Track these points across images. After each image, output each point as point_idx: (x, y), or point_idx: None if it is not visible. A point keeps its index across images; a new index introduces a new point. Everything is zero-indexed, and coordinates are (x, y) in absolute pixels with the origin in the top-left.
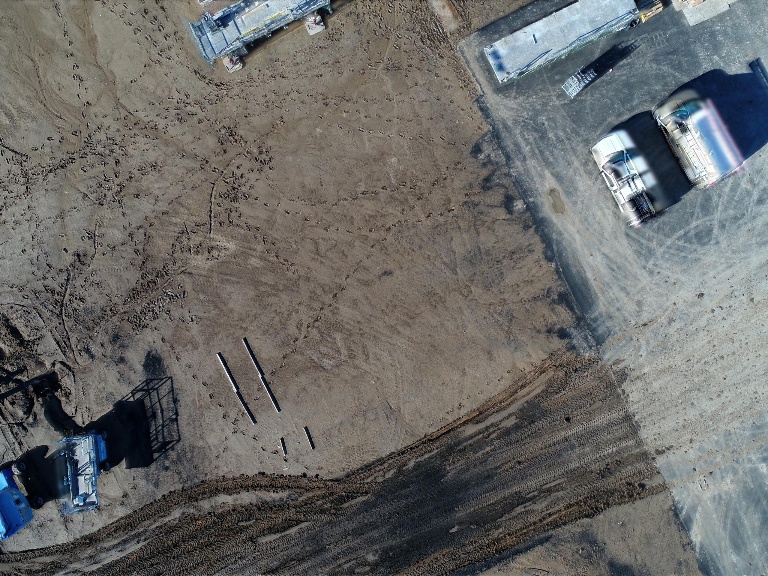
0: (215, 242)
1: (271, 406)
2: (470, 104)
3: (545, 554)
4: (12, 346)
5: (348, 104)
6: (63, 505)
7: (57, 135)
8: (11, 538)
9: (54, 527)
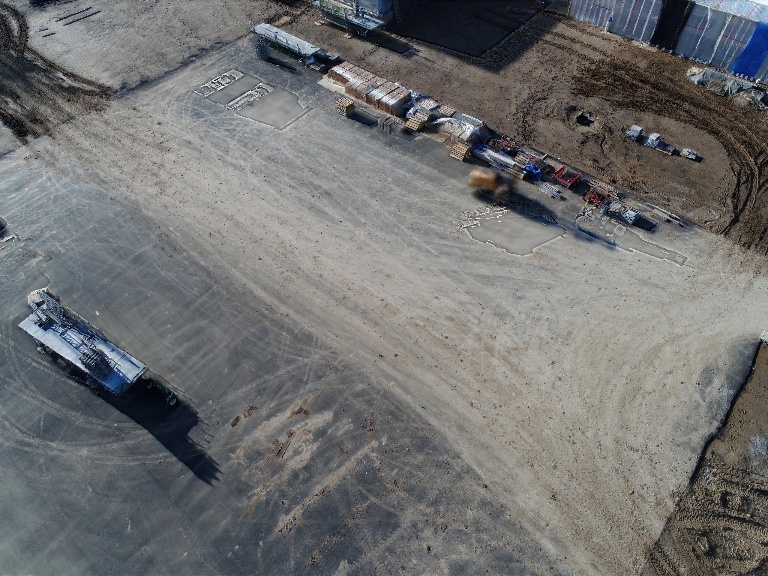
0: None
1: None
2: None
3: None
4: None
5: None
6: None
7: None
8: None
9: None
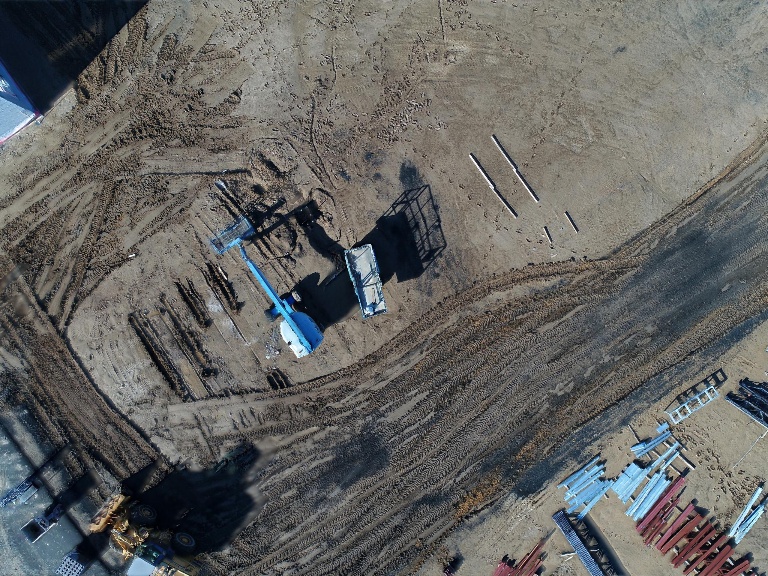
0: (449, 46)
1: (529, 197)
2: None
3: None
4: (269, 180)
5: None
6: (343, 328)
7: None
8: (298, 369)
9: (337, 352)
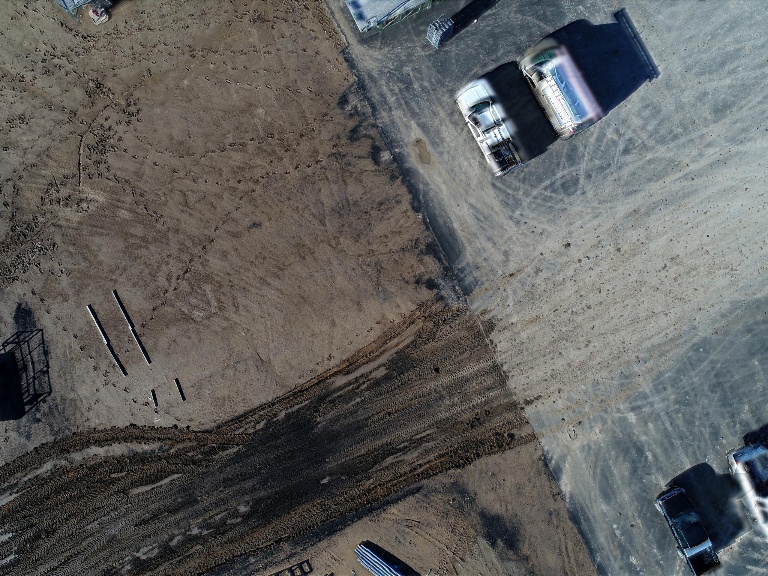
0: (84, 194)
1: (142, 358)
2: (336, 55)
3: (416, 505)
4: None
5: (215, 56)
6: None
7: None
8: None
9: None
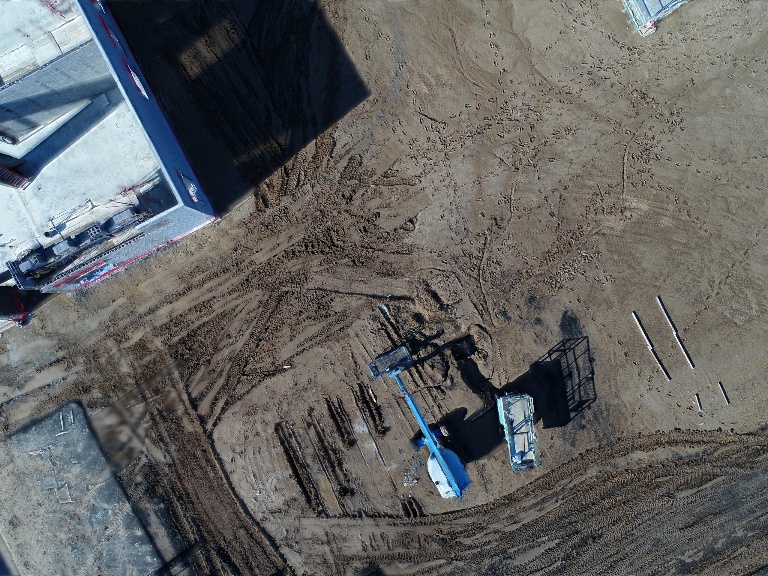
0: (628, 203)
1: (685, 362)
2: None
3: None
4: (432, 310)
5: (757, 64)
6: (482, 466)
7: (474, 102)
8: (432, 500)
9: (474, 488)
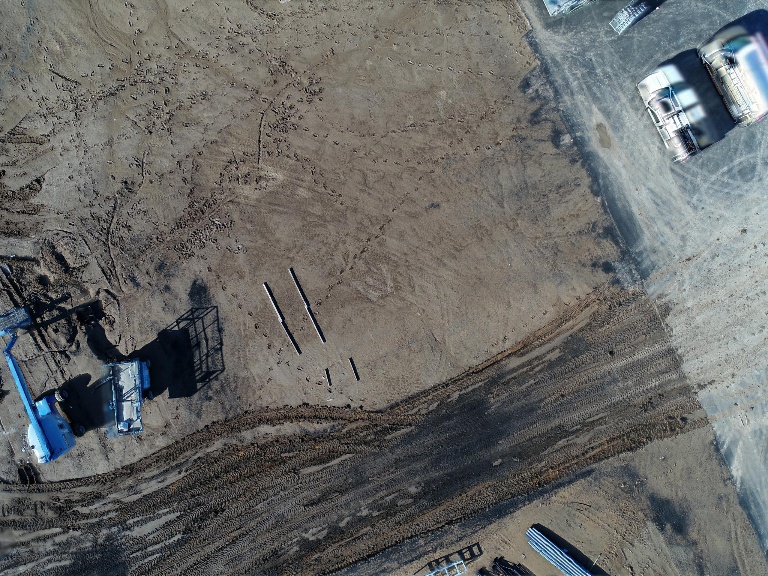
0: (263, 172)
1: (316, 337)
2: (519, 39)
3: (587, 488)
4: (57, 273)
5: (398, 37)
6: (105, 434)
7: (107, 62)
8: (51, 467)
9: (95, 457)
